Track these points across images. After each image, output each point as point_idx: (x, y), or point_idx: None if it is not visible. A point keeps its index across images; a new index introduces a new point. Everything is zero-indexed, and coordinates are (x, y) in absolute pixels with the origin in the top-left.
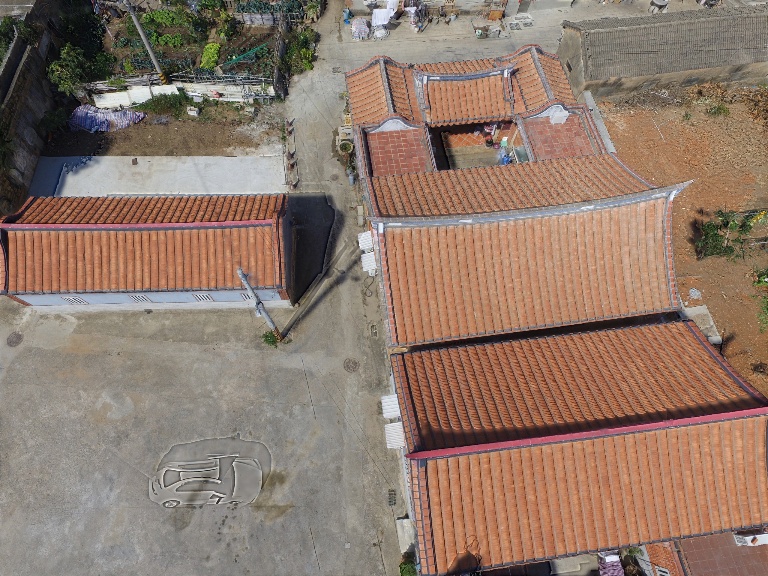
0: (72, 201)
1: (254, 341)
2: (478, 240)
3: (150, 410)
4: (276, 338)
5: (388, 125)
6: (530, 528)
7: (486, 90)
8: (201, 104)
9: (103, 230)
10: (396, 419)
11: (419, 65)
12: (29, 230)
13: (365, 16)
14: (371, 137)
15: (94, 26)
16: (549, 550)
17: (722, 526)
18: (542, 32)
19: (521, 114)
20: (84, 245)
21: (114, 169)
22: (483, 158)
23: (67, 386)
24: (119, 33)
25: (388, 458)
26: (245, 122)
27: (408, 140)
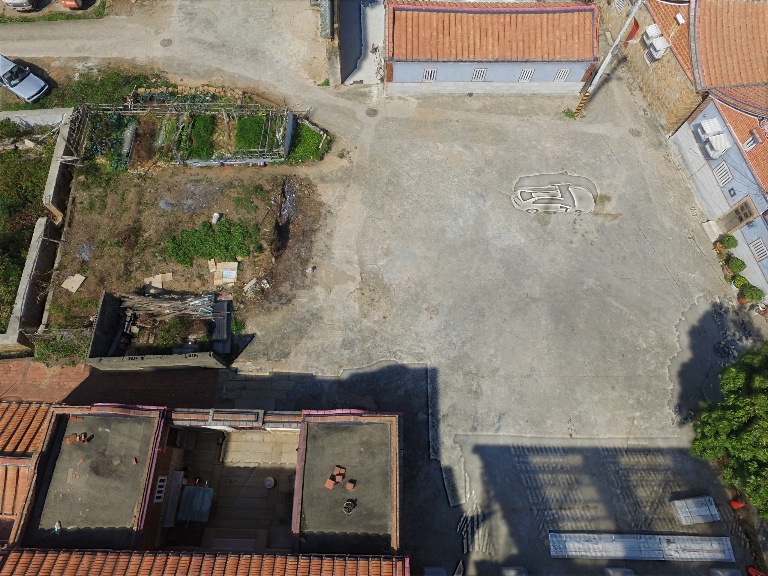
0: (420, 2)
1: (557, 115)
2: (762, 13)
3: (494, 156)
4: (577, 111)
5: None
6: None
7: None
8: None
9: (464, 13)
10: None
11: None
12: (411, 11)
13: None
14: None
15: None
16: None
17: None
18: None
19: None
20: (449, 25)
21: None
22: None
23: (426, 140)
24: None
25: (682, 188)
26: None
27: None
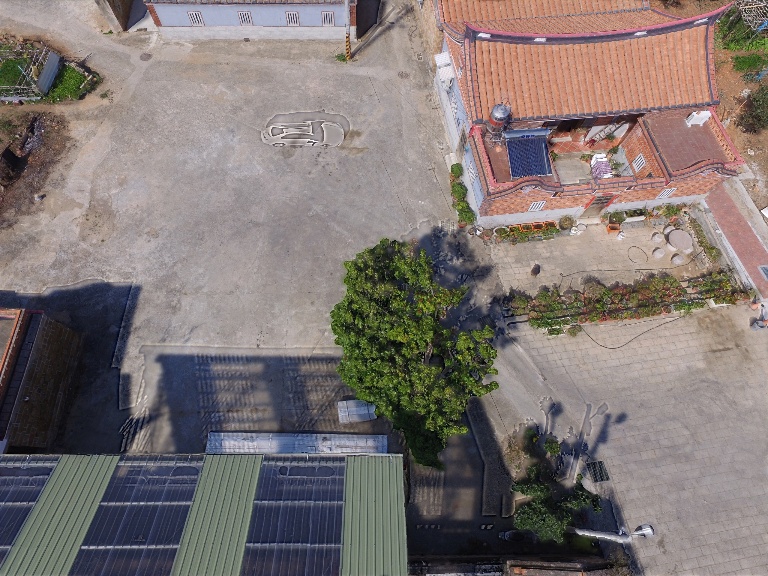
0: None
1: (329, 59)
2: None
3: (256, 95)
4: (347, 55)
5: None
6: (545, 98)
7: None
8: None
9: None
10: None
11: None
12: None
13: None
14: None
15: None
16: (558, 111)
17: (676, 103)
18: None
19: None
20: None
21: None
22: None
23: (191, 81)
24: None
25: (436, 125)
26: None
27: None
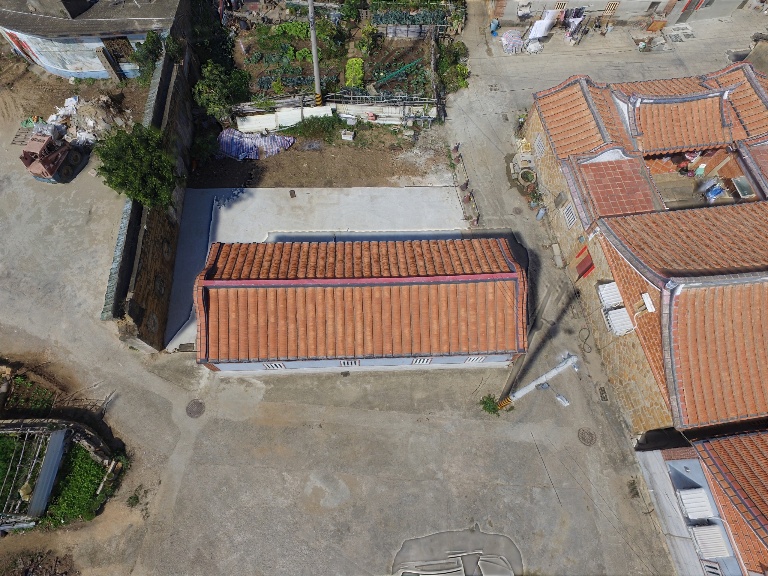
0: (264, 248)
1: (472, 409)
2: None
3: (369, 496)
4: (500, 406)
5: (605, 155)
6: None
7: (702, 114)
8: (354, 127)
9: (319, 286)
10: (704, 520)
11: (615, 85)
12: (234, 287)
13: (513, 27)
14: (584, 169)
15: (223, 39)
16: None
17: None
18: (707, 44)
19: (745, 141)
20: (296, 304)
21: (271, 203)
22: (676, 187)
23: (267, 467)
24: (250, 47)
25: (655, 553)
26: (406, 147)
27: (626, 172)
